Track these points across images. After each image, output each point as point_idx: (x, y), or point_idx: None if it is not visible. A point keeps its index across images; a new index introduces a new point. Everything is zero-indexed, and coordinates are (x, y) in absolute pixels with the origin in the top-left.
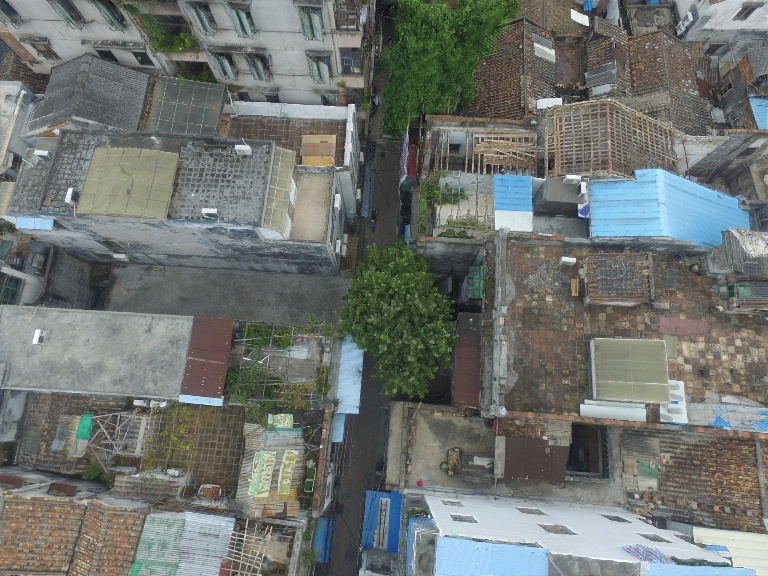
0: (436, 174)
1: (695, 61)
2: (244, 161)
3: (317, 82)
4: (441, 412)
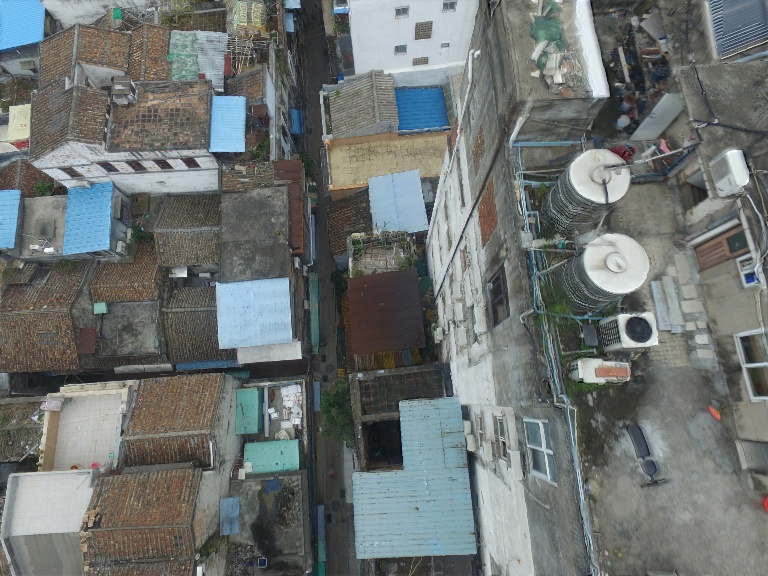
0: None
1: None
2: None
3: None
4: None
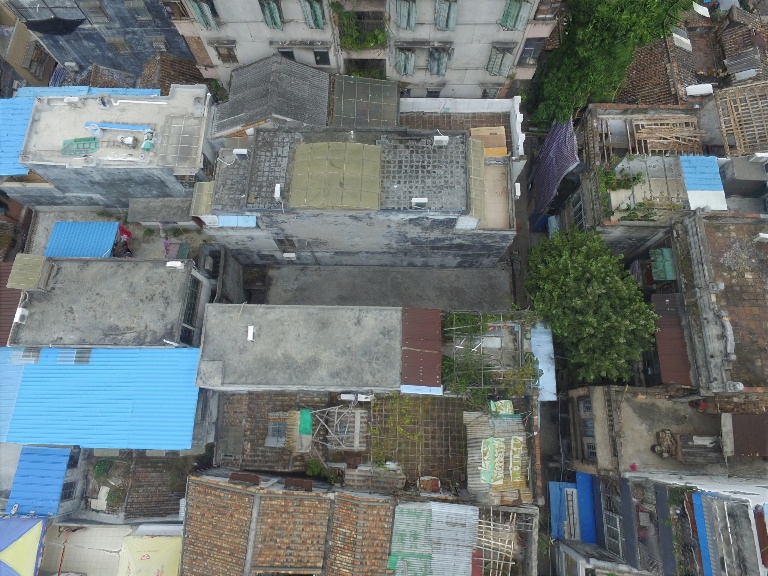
0: (619, 159)
1: None
2: (441, 152)
3: (493, 74)
4: (645, 394)
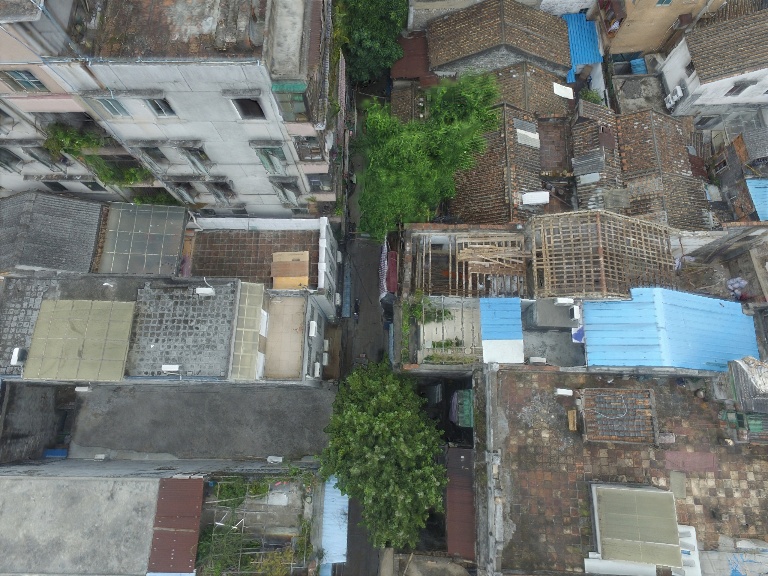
0: (417, 298)
1: (687, 136)
2: (207, 303)
3: (284, 203)
4: (435, 561)
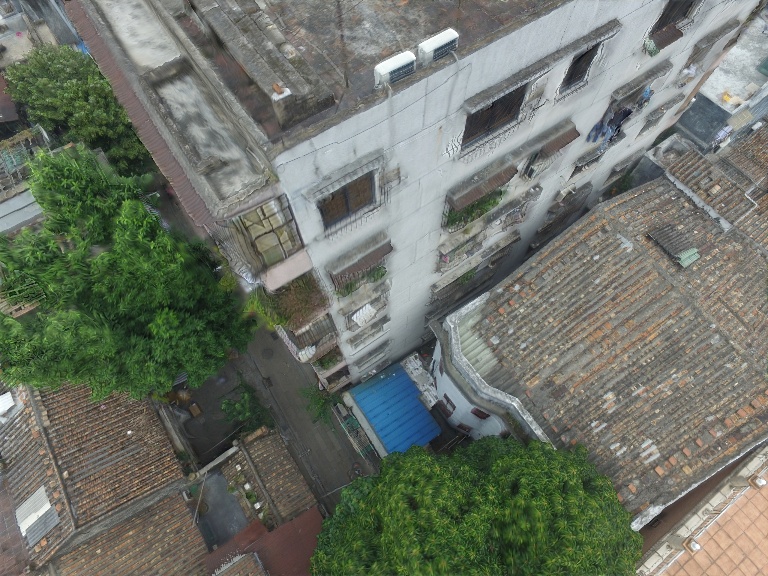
0: None
1: None
2: None
3: None
4: None
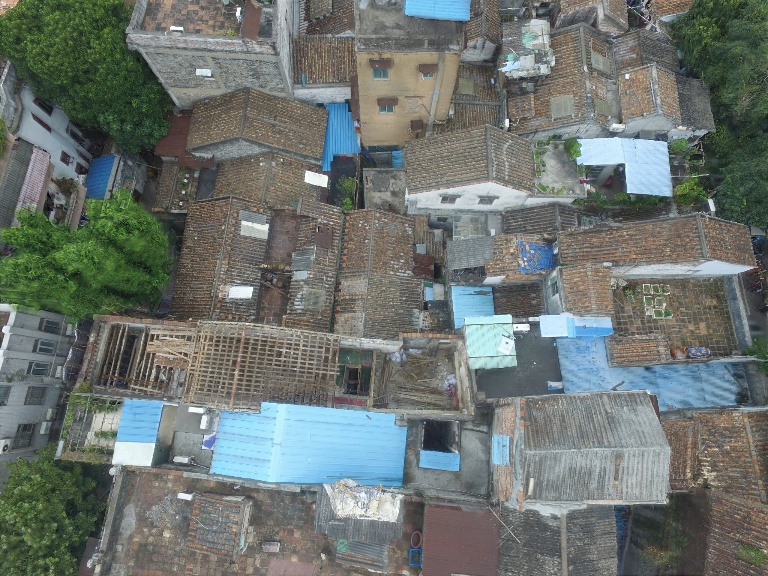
0: None
1: (419, 234)
2: None
3: None
4: None
